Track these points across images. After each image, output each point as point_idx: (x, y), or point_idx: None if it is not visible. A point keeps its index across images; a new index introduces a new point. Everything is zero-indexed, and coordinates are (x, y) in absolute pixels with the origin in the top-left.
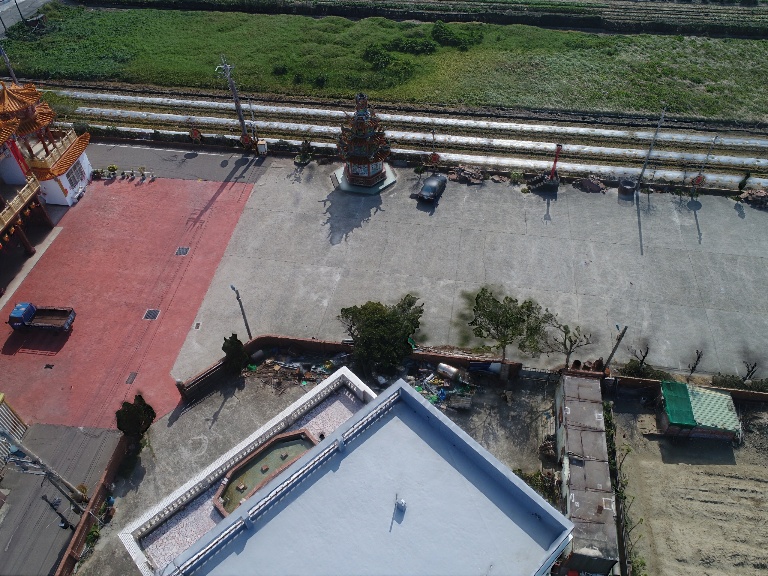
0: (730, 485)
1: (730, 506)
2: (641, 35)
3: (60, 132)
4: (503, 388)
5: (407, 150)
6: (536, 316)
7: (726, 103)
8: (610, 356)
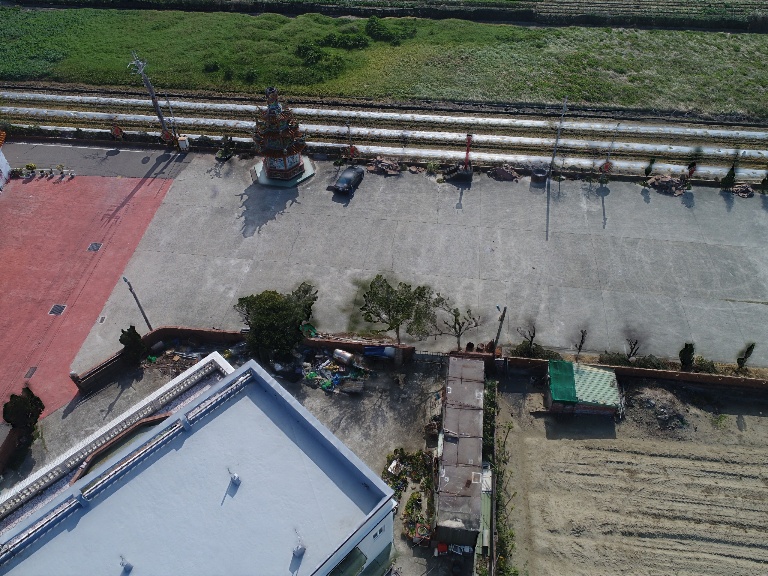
0: (608, 458)
1: (606, 478)
2: (571, 28)
3: None
4: (397, 372)
5: (330, 143)
6: (427, 300)
7: (645, 92)
8: (496, 337)
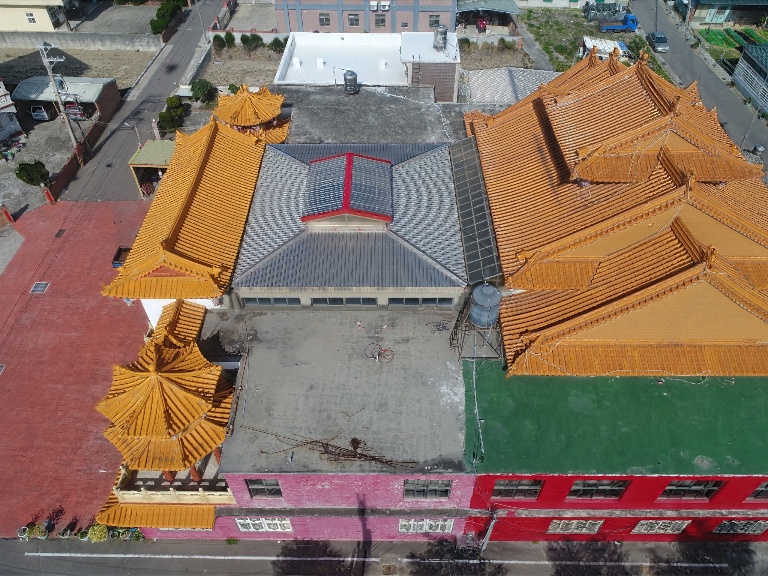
0: None
1: None
2: None
3: None
4: None
5: None
6: None
7: None
8: None
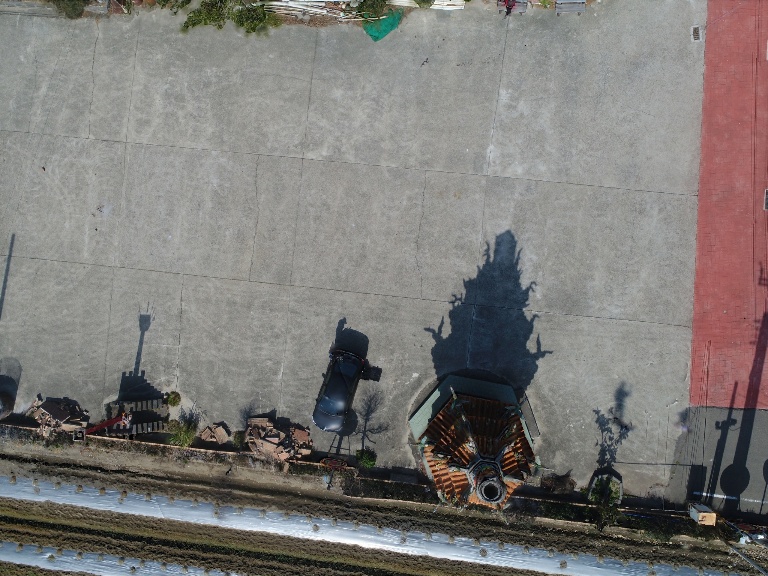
0: None
1: None
2: None
3: None
4: None
5: (393, 549)
6: None
7: None
8: None
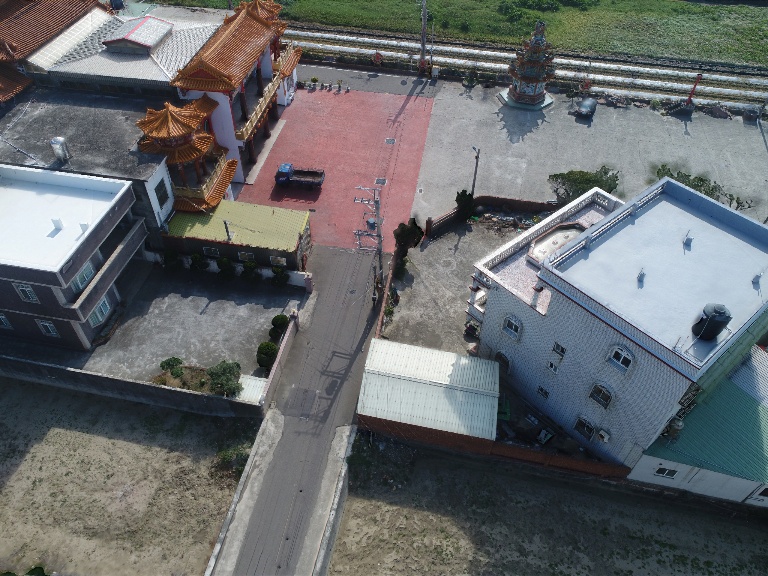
0: None
1: None
2: (740, 6)
3: (280, 44)
4: None
5: None
6: (708, 185)
7: None
8: None
